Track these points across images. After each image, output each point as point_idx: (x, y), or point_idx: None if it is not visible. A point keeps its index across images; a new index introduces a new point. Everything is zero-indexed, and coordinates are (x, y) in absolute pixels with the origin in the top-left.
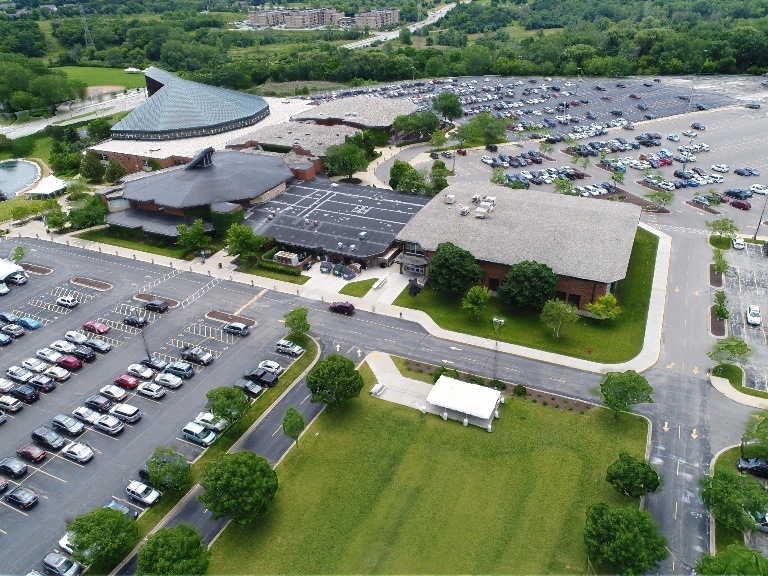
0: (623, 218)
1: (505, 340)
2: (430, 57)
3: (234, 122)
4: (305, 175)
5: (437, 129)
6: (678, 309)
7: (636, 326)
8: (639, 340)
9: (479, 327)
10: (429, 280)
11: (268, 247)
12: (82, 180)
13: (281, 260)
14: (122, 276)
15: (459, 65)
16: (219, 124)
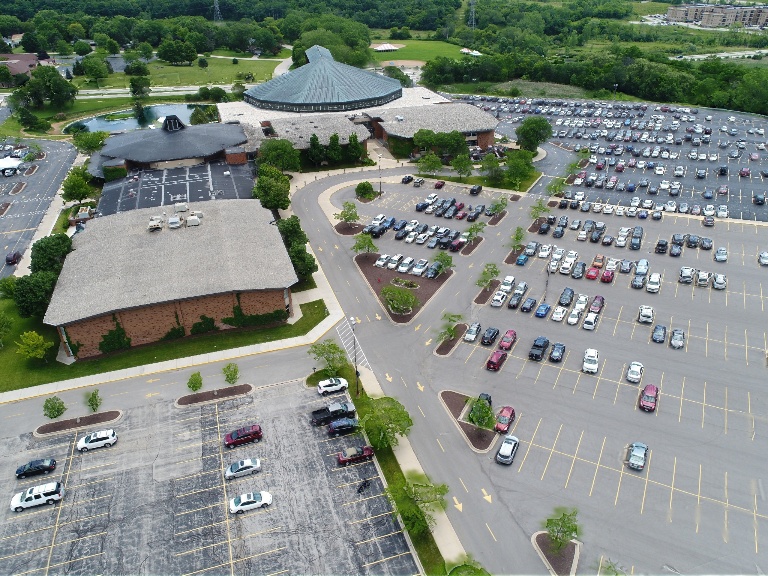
0: (216, 284)
1: None
2: (734, 78)
3: (322, 105)
4: (226, 158)
5: None
6: None
7: (40, 379)
8: (7, 388)
9: (4, 312)
10: None
11: None
12: None
13: None
14: (34, 190)
15: (719, 93)
16: (305, 104)
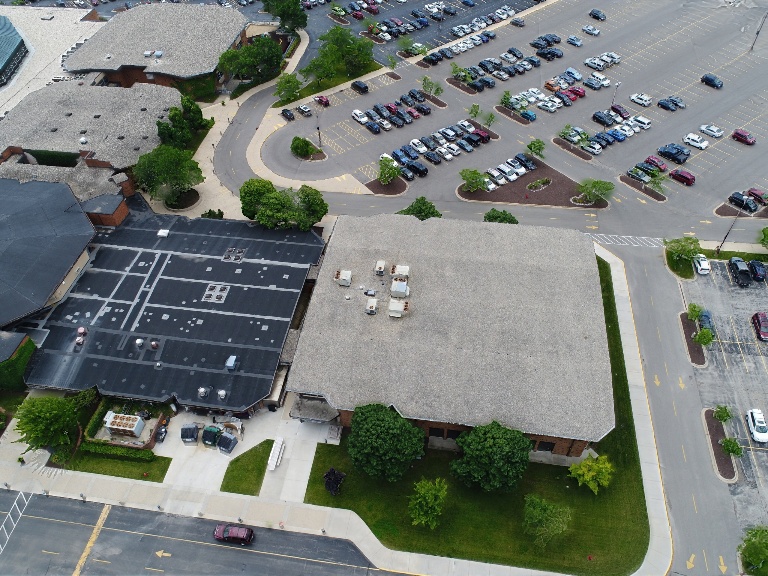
0: (580, 280)
1: (477, 557)
2: None
3: None
4: (113, 220)
5: (280, 59)
6: (669, 426)
7: (631, 480)
8: (642, 513)
9: (436, 533)
10: (344, 430)
11: (90, 403)
12: None
13: (117, 431)
14: None
15: None
16: None
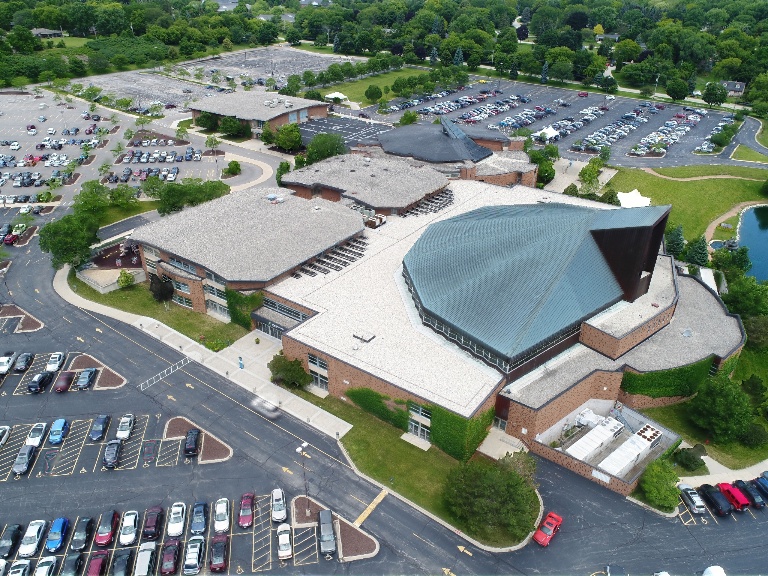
0: None
1: None
2: None
3: None
4: None
5: None
6: None
7: None
8: None
9: None
10: None
11: None
12: (584, 179)
13: None
14: None
15: None
16: None
